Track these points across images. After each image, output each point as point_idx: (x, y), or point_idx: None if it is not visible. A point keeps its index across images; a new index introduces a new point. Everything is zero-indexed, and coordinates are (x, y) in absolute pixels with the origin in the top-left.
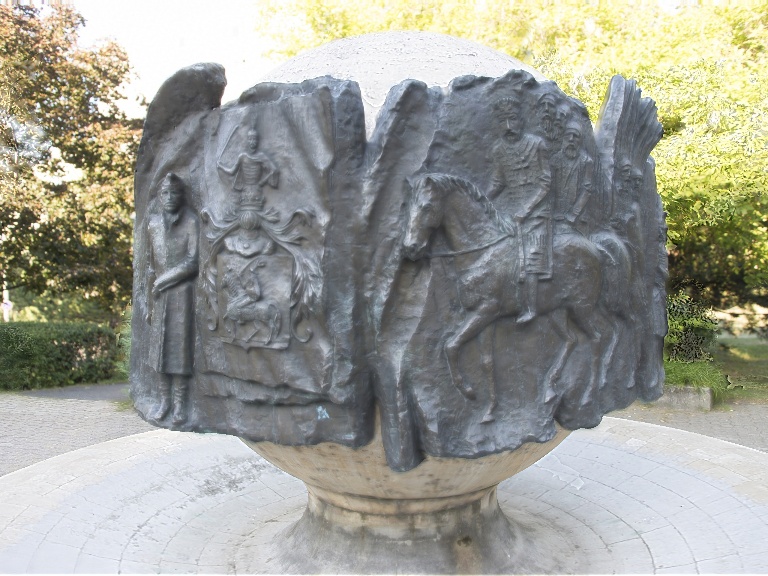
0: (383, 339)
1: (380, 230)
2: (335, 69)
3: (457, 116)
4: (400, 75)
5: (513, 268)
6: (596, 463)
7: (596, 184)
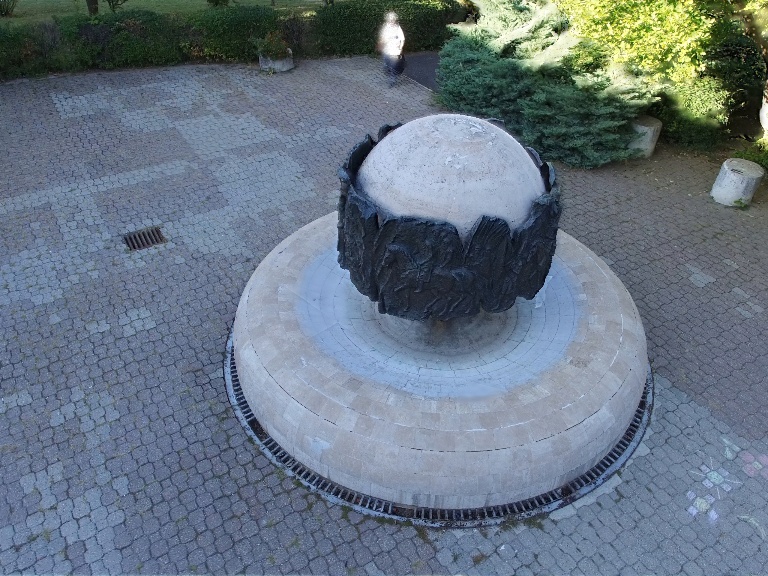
0: (379, 281)
1: (379, 255)
2: (393, 176)
3: (405, 230)
4: (408, 191)
5: (416, 277)
6: (556, 299)
7: (458, 255)
